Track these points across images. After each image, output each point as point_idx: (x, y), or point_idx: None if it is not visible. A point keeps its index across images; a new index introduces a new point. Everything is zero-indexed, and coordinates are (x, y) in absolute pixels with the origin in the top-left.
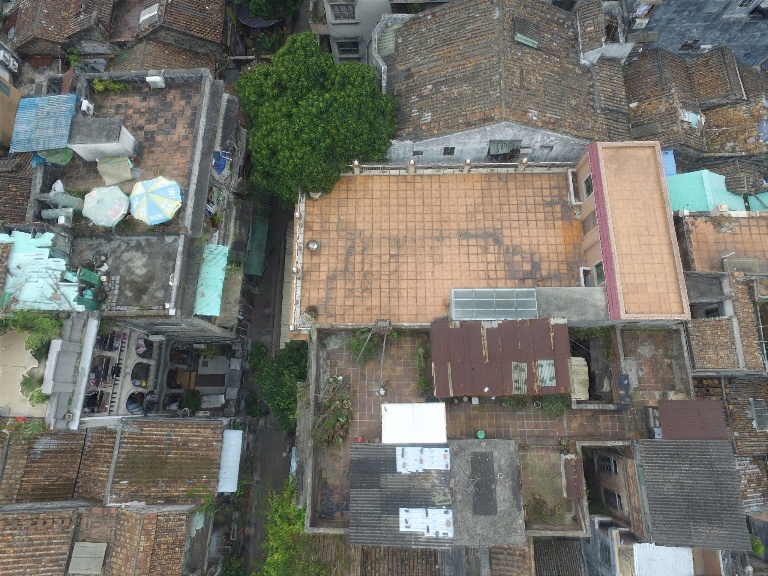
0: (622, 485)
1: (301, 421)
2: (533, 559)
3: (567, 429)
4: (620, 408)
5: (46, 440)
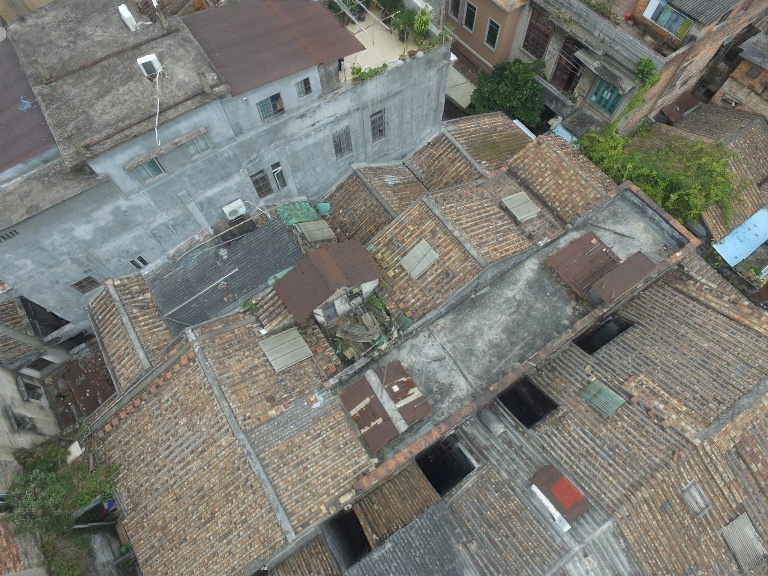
0: None
1: (578, 32)
2: None
3: None
4: None
5: (389, 177)
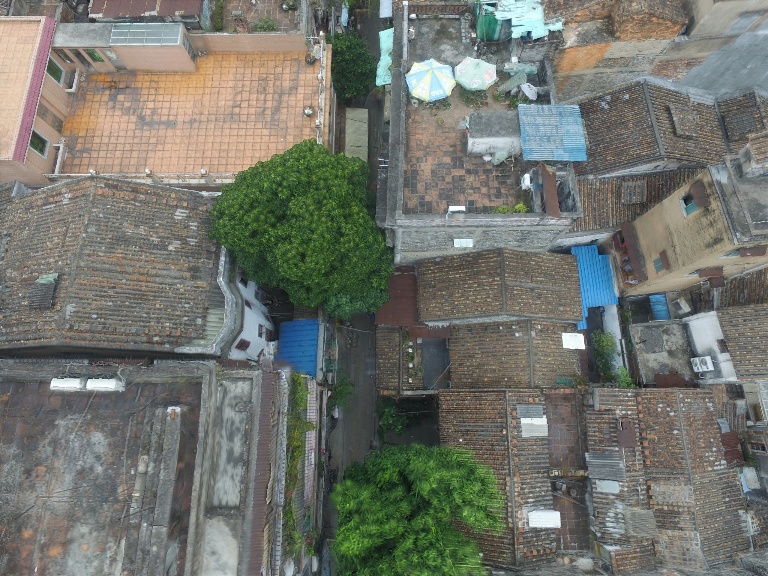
0: None
1: None
2: None
3: None
4: None
5: None
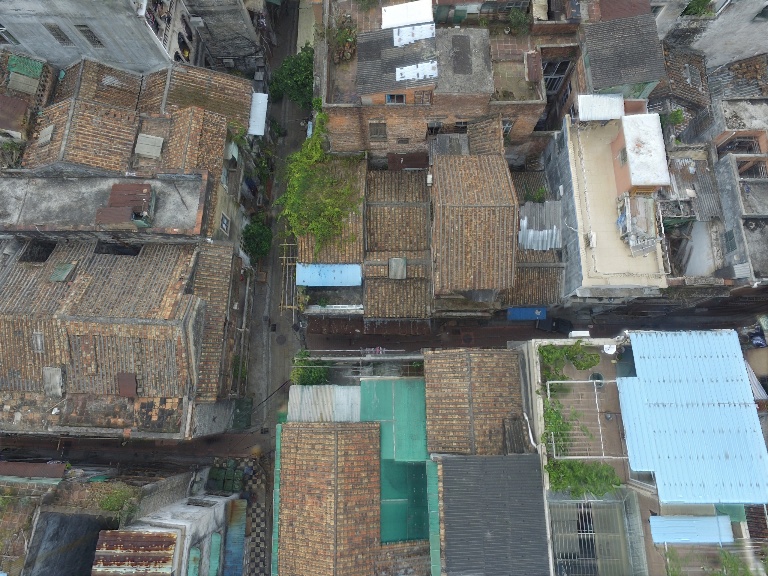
0: (575, 91)
1: (317, 49)
2: (502, 130)
3: (531, 49)
4: (572, 22)
5: (111, 79)
